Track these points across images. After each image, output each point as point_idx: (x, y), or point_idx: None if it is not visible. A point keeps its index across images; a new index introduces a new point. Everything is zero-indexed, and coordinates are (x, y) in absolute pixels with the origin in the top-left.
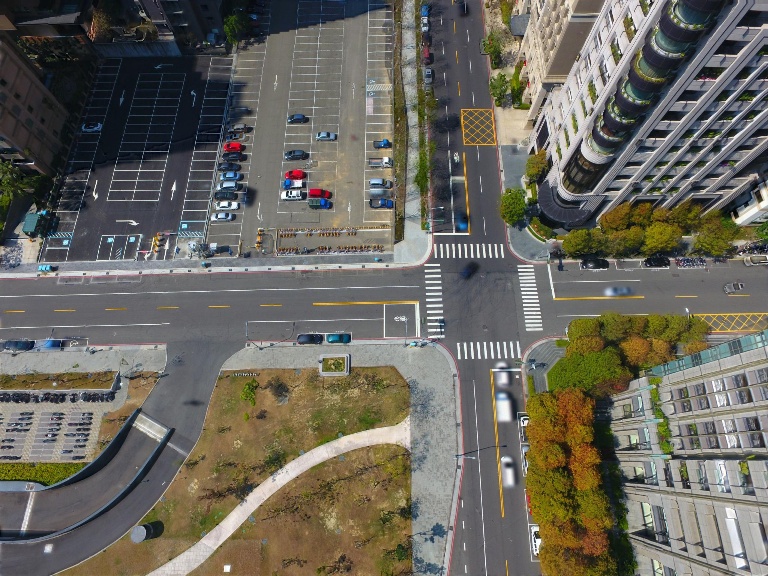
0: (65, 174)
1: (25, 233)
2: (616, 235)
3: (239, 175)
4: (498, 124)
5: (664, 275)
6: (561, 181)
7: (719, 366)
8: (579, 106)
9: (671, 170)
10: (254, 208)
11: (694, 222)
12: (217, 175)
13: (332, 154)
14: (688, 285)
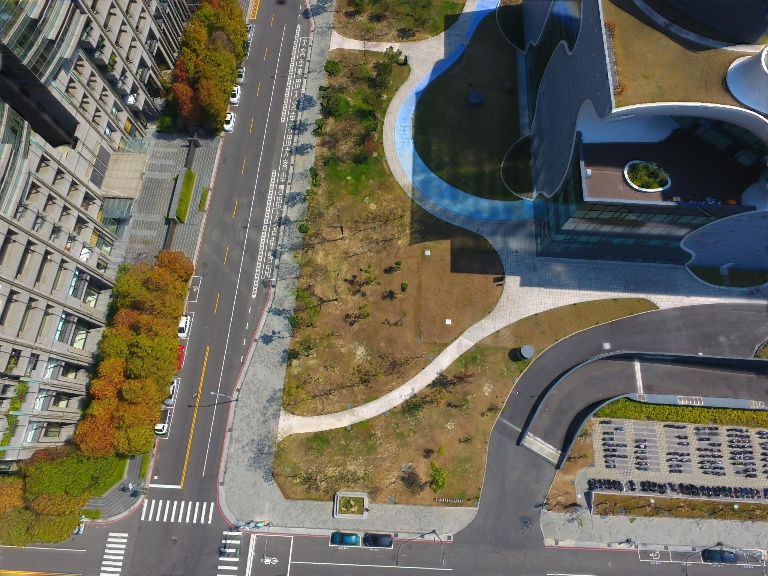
0: None
1: None
2: None
3: None
4: None
5: None
6: None
7: None
8: None
9: None
10: None
11: None
12: None
13: None
14: None
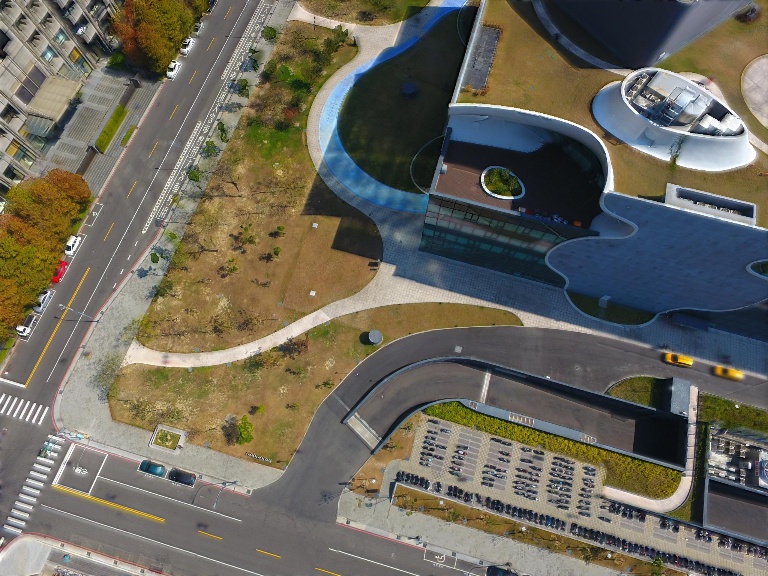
0: None
1: None
2: None
3: None
4: None
5: None
6: None
7: None
8: None
9: None
10: None
11: None
12: None
13: None
14: None
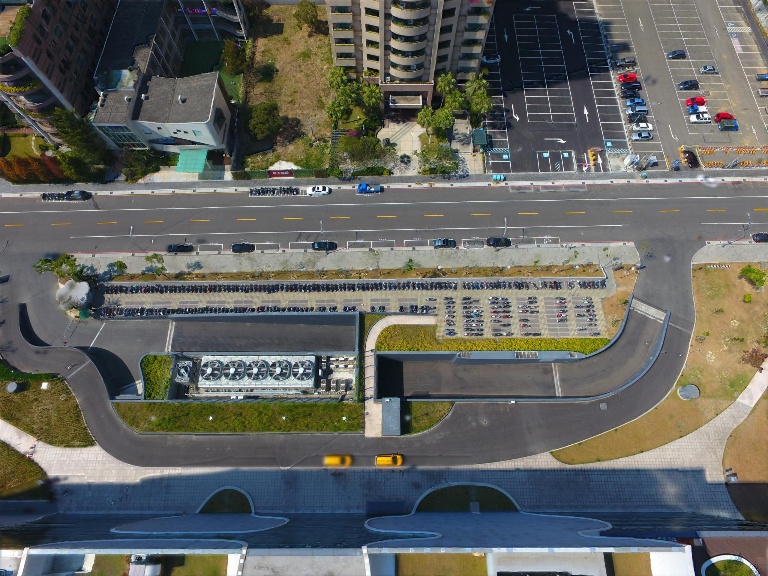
0: None
1: None
2: None
3: (644, 101)
4: None
5: None
6: None
7: None
8: None
9: None
10: (666, 130)
11: None
12: (620, 102)
13: (719, 85)
14: None
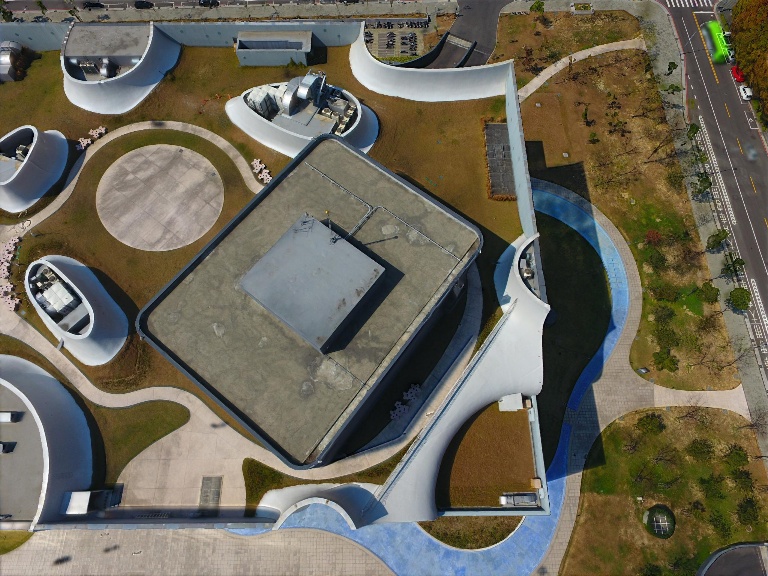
0: None
1: None
2: None
3: None
4: None
5: None
6: None
7: None
8: None
9: None
10: None
11: None
12: None
13: None
14: None
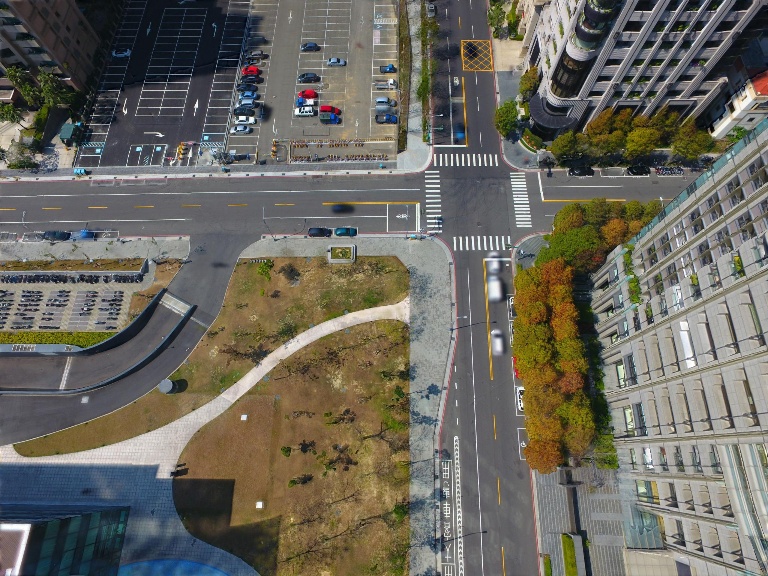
0: (97, 93)
1: (62, 141)
2: (599, 138)
3: (256, 94)
4: (495, 53)
5: (644, 182)
6: (549, 87)
7: (679, 211)
8: (565, 11)
9: (647, 70)
10: (270, 123)
11: (671, 129)
12: (236, 95)
13: (342, 78)
14: (666, 190)
